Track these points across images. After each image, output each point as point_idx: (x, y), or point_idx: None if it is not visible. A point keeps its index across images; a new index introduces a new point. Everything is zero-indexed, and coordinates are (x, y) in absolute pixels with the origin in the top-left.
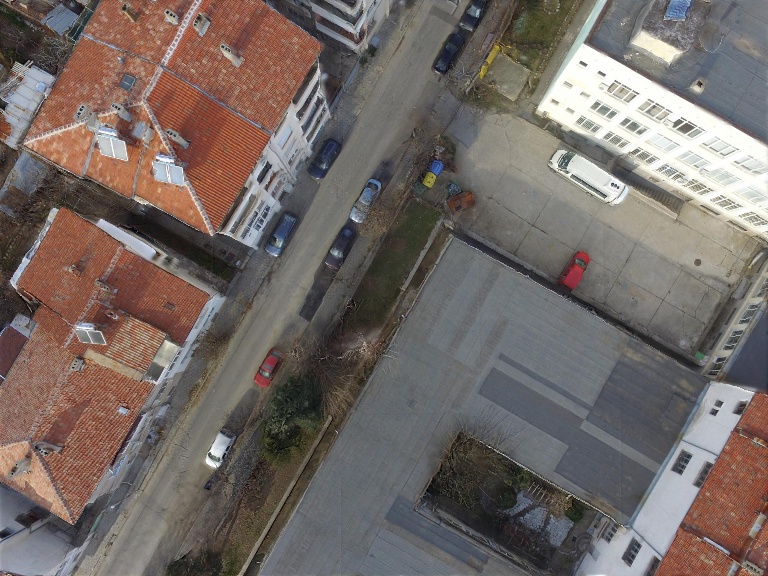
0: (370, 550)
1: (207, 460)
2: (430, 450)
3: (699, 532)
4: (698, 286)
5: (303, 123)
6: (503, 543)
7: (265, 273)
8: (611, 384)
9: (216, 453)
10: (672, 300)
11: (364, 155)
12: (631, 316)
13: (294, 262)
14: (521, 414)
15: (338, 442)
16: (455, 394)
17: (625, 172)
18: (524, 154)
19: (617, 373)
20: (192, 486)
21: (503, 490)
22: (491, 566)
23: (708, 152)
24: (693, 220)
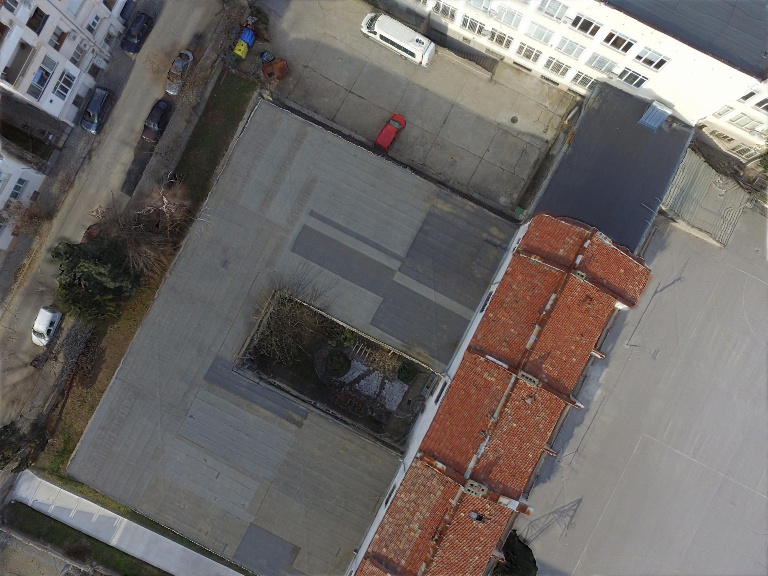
0: (189, 412)
1: (33, 339)
2: (245, 310)
3: (482, 352)
4: (516, 143)
5: None
6: (335, 407)
7: (85, 151)
8: (422, 235)
9: (39, 329)
10: (491, 158)
11: (178, 29)
12: (451, 175)
13: (113, 139)
14: (334, 269)
15: (154, 307)
16: (268, 253)
17: (442, 37)
18: (338, 21)
19: (428, 224)
20: (22, 368)
21: None
22: (311, 421)
23: None
24: (508, 78)
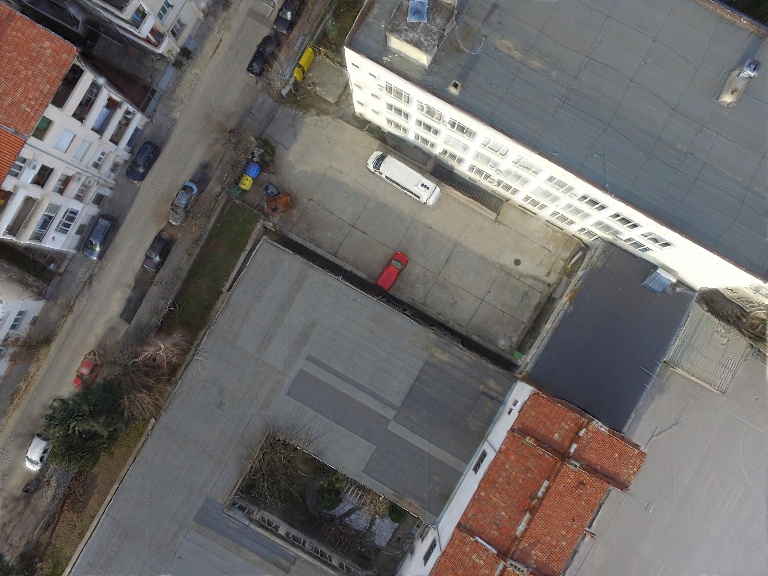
0: (178, 552)
1: (27, 463)
2: (238, 451)
3: (472, 532)
4: (518, 286)
5: (91, 126)
6: None
7: (86, 276)
8: (419, 384)
9: (32, 456)
10: (492, 300)
11: (183, 158)
12: (450, 316)
13: (115, 265)
14: (329, 415)
15: (147, 444)
16: (264, 395)
17: (448, 173)
18: (344, 155)
19: (425, 373)
20: (14, 489)
21: (326, 491)
22: (299, 567)
23: (490, 152)
24: (512, 220)
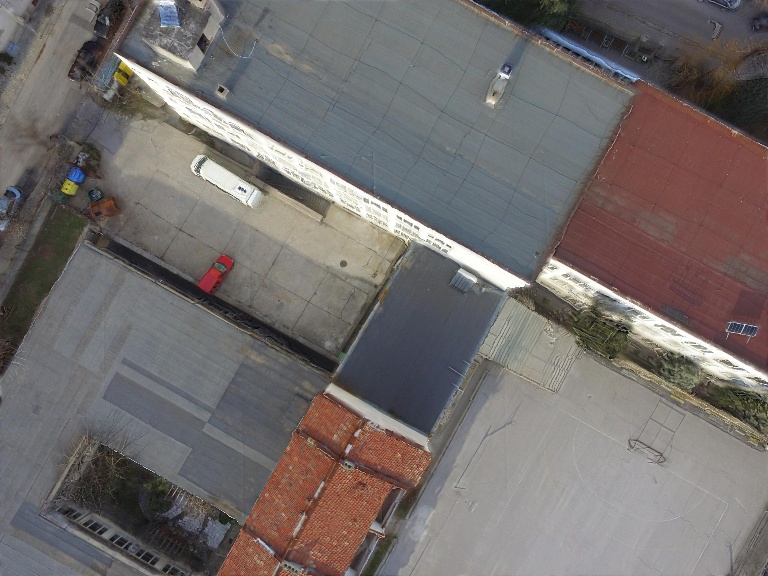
0: None
1: None
2: (55, 455)
3: (254, 533)
4: (344, 287)
5: None
6: None
7: None
8: (234, 386)
9: None
10: (318, 301)
11: (9, 163)
12: (277, 318)
13: None
14: (145, 418)
15: None
16: (80, 399)
17: (278, 175)
18: (171, 159)
19: (240, 375)
20: None
21: (157, 493)
22: (115, 570)
23: None
24: (338, 222)
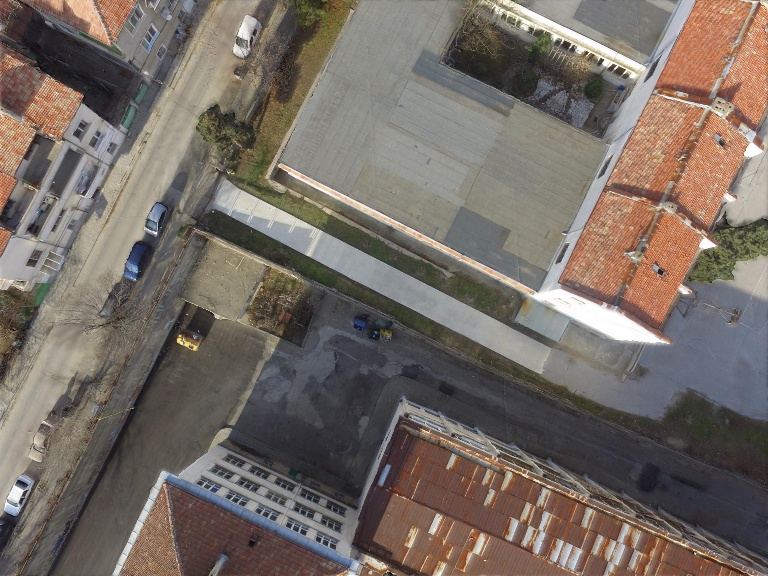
0: (399, 101)
1: (235, 50)
2: (452, 5)
3: None
4: None
5: None
6: None
7: None
8: None
9: (244, 35)
10: None
11: None
12: None
13: None
14: None
15: (362, 4)
16: None
17: None
18: None
19: None
20: (221, 82)
21: None
22: (517, 111)
23: None
24: None
